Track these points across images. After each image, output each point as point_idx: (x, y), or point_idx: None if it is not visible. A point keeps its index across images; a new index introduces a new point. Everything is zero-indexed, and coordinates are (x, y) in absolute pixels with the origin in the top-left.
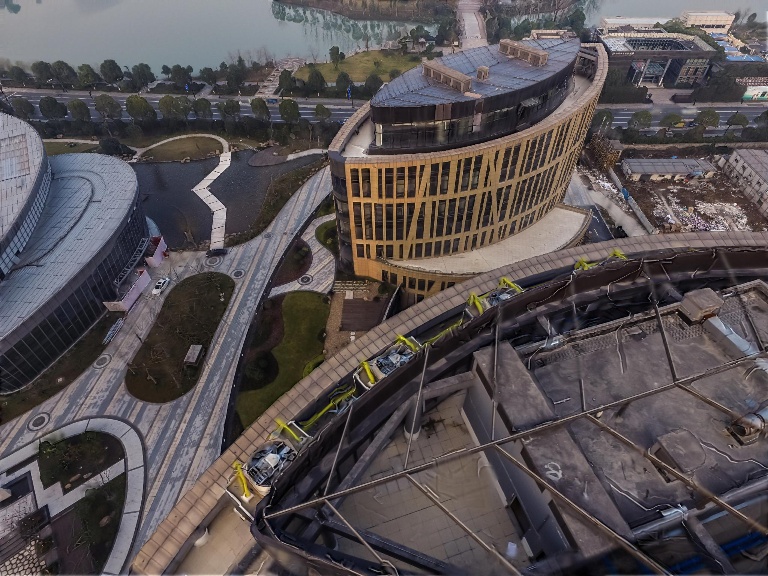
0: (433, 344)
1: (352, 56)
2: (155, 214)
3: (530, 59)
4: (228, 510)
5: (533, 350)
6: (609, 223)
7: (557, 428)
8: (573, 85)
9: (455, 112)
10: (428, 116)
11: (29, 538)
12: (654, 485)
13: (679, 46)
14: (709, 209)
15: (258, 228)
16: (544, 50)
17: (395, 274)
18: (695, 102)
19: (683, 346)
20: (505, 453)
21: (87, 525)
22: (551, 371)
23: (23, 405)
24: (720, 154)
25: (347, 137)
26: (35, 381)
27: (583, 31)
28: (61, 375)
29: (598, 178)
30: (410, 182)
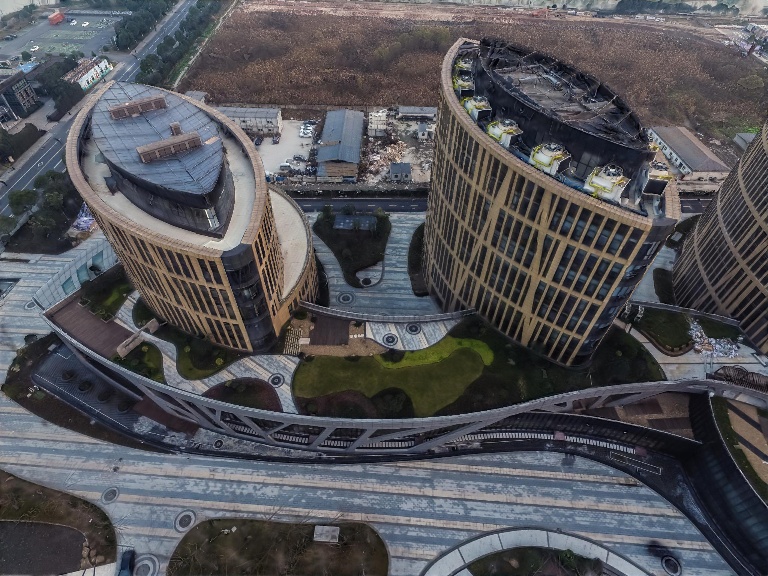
0: (562, 122)
1: None
2: None
3: (155, 106)
4: None
5: None
6: None
7: None
8: None
9: None
10: None
11: None
12: None
13: None
14: None
15: (85, 513)
16: None
17: (295, 298)
18: (66, 112)
19: (527, 90)
20: (599, 111)
21: None
22: None
23: None
24: None
25: None
26: None
27: None
28: None
29: None
30: None
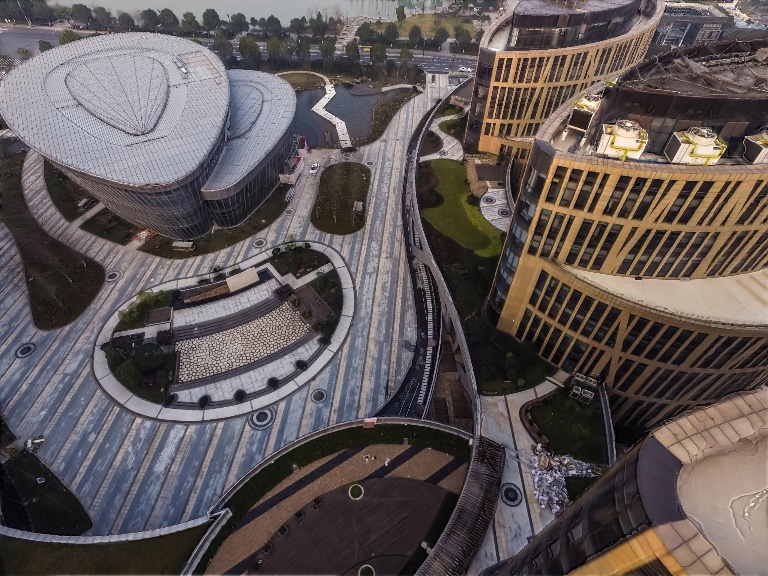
0: None
1: (410, 17)
2: None
3: None
4: (560, 133)
5: None
6: None
7: (717, 74)
8: (639, 16)
9: (570, 22)
10: (553, 23)
11: (282, 300)
12: None
13: (697, 13)
14: None
15: (375, 135)
16: None
17: (511, 147)
18: None
19: (757, 70)
20: None
21: (321, 293)
22: None
23: (244, 234)
24: None
25: None
26: (245, 222)
27: None
28: (263, 218)
29: None
30: (537, 70)
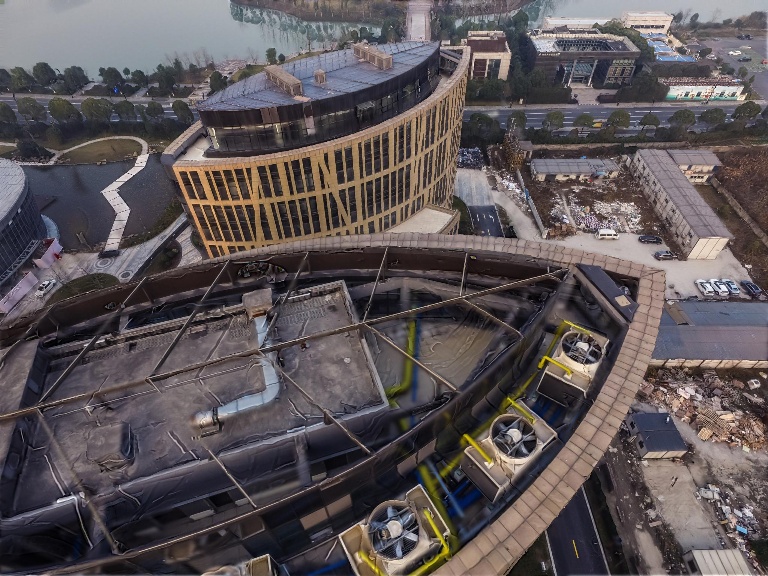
0: None
1: (294, 57)
2: (59, 216)
3: (377, 62)
4: None
5: (75, 348)
6: (504, 223)
7: (7, 422)
8: (431, 88)
9: (283, 115)
10: (255, 119)
11: None
12: (92, 475)
13: (607, 47)
14: (605, 209)
15: (156, 230)
16: (397, 53)
17: None
18: (619, 102)
19: (232, 344)
20: None
21: None
22: (88, 368)
23: None
24: (630, 154)
25: (189, 140)
26: None
27: (521, 32)
28: None
29: (504, 178)
30: (242, 184)
